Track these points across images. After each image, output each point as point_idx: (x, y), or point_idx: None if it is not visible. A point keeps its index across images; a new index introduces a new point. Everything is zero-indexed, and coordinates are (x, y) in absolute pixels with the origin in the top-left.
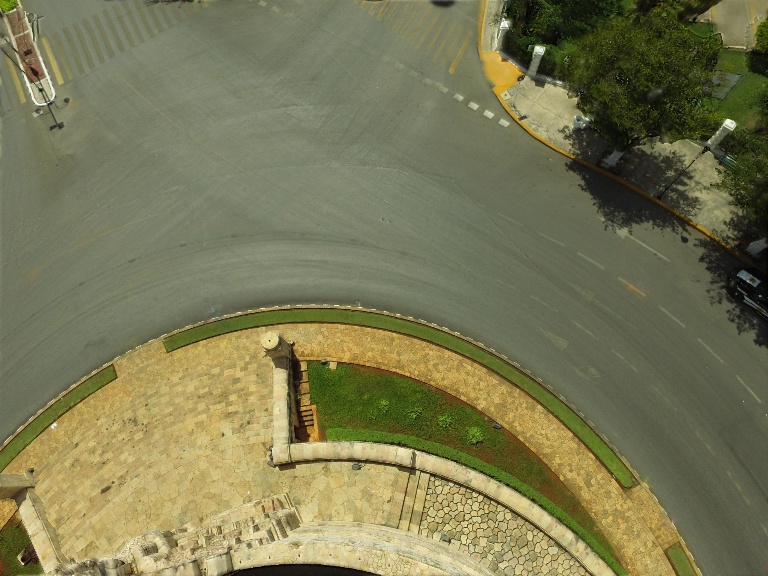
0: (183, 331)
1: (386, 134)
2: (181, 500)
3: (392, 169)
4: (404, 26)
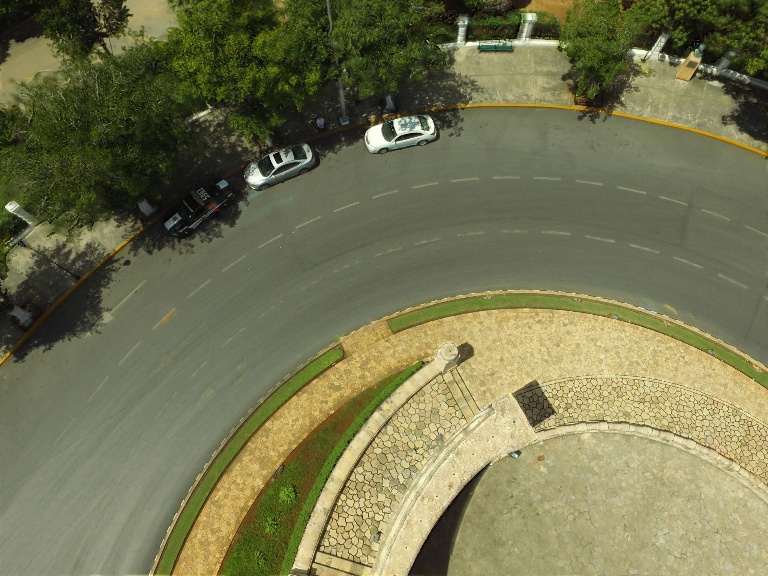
0: None
1: None
2: None
3: None
4: None
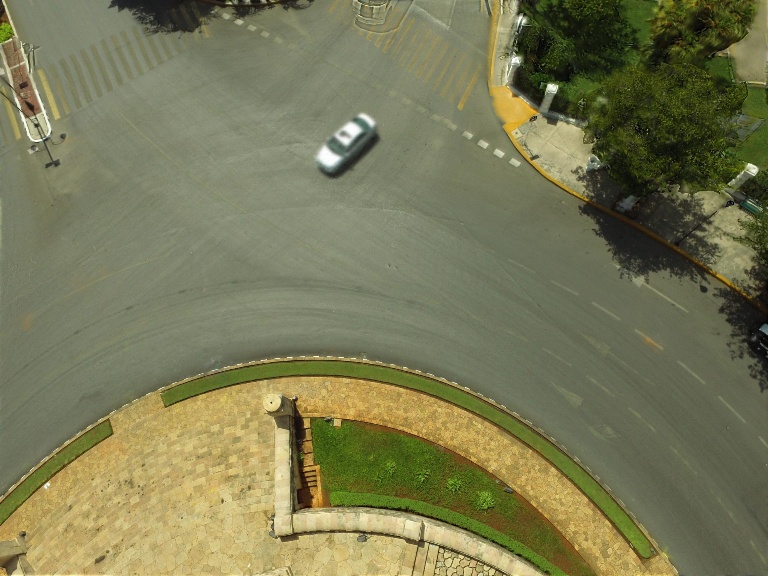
0: (182, 384)
1: (393, 174)
2: (178, 573)
3: (399, 211)
4: (411, 59)
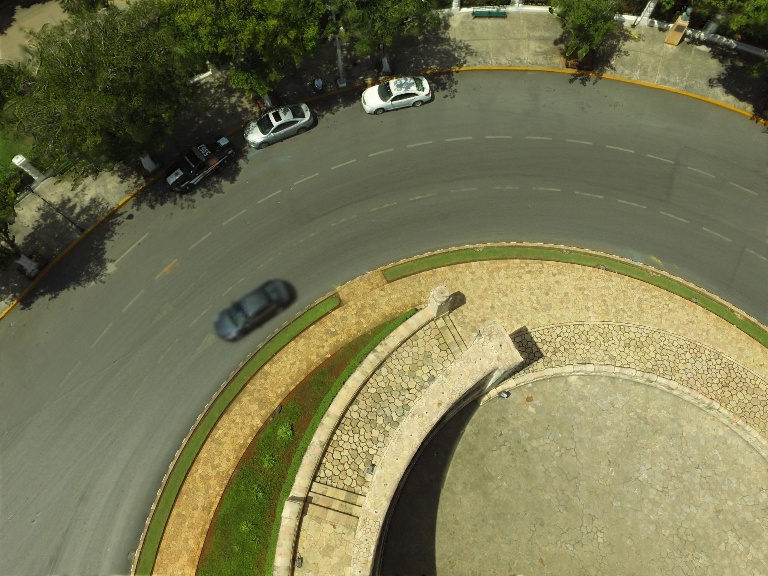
0: None
1: None
2: None
3: None
4: None
